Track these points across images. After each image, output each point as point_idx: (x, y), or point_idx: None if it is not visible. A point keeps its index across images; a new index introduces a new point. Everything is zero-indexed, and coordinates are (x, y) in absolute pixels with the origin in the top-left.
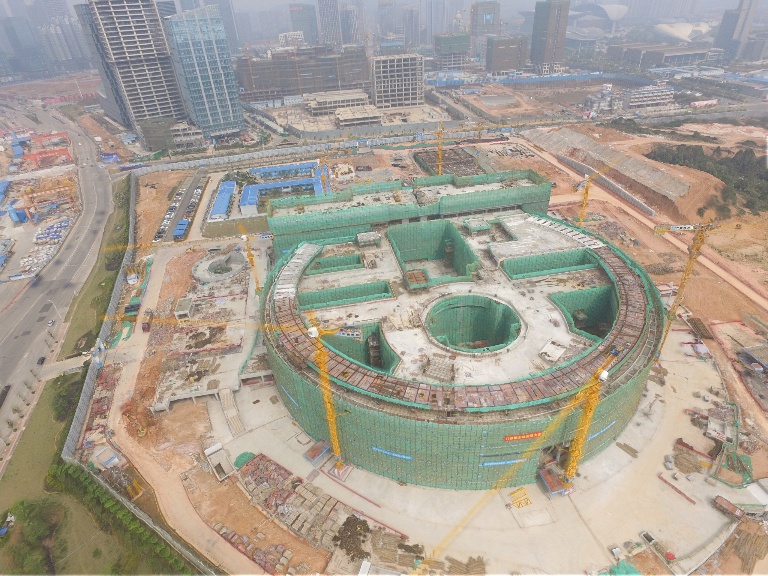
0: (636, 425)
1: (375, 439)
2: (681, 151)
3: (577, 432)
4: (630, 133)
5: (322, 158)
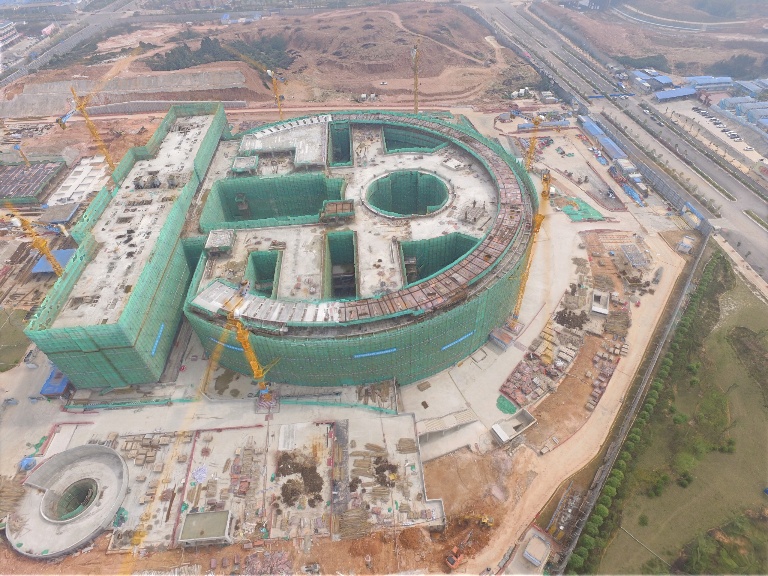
0: None
1: None
2: (172, 57)
3: None
4: (94, 64)
5: None
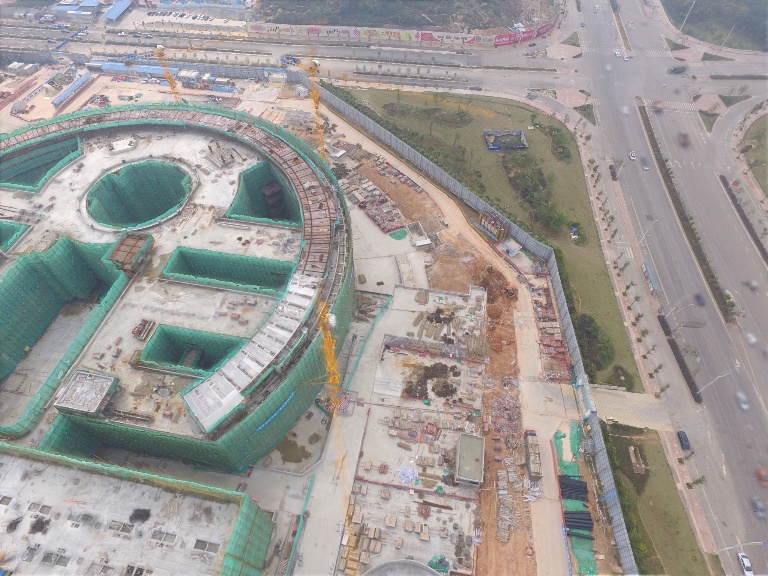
0: None
1: None
2: None
3: None
4: None
5: None
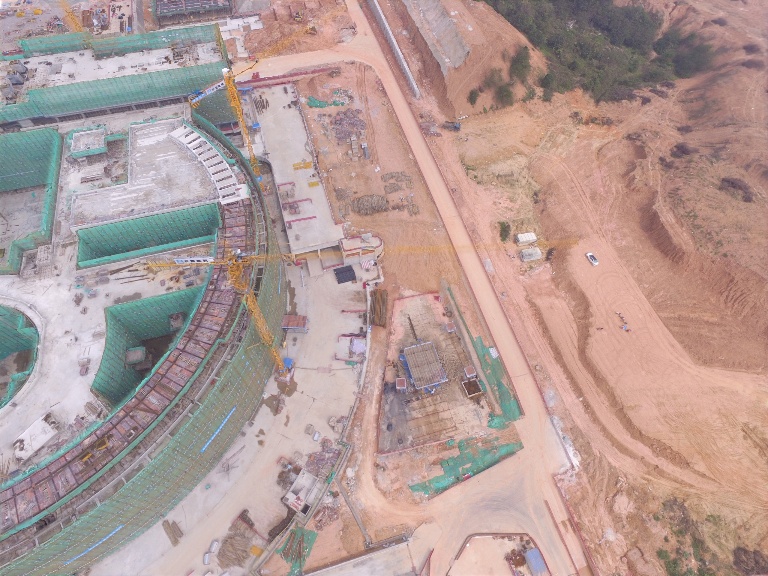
0: (204, 488)
1: None
2: None
3: None
4: None
5: None
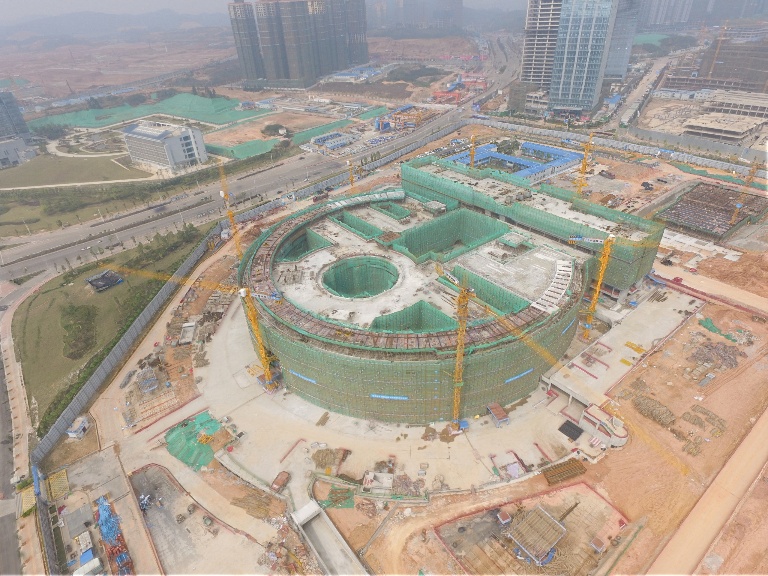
0: (354, 422)
1: None
2: None
3: (277, 352)
4: None
5: (594, 153)
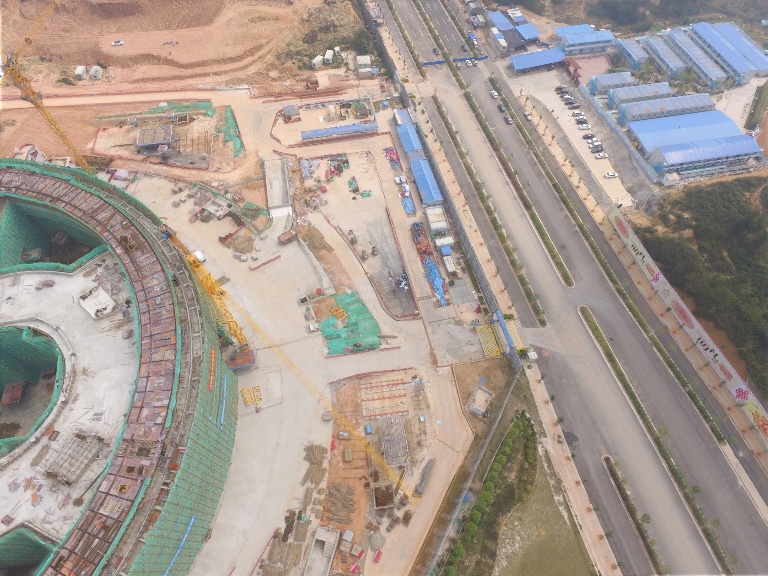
0: None
1: (157, 573)
2: None
3: (212, 315)
4: None
5: None
